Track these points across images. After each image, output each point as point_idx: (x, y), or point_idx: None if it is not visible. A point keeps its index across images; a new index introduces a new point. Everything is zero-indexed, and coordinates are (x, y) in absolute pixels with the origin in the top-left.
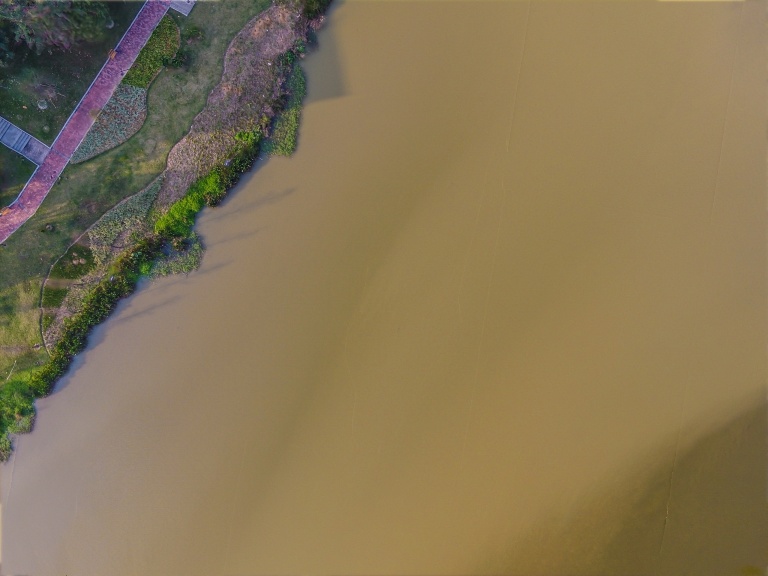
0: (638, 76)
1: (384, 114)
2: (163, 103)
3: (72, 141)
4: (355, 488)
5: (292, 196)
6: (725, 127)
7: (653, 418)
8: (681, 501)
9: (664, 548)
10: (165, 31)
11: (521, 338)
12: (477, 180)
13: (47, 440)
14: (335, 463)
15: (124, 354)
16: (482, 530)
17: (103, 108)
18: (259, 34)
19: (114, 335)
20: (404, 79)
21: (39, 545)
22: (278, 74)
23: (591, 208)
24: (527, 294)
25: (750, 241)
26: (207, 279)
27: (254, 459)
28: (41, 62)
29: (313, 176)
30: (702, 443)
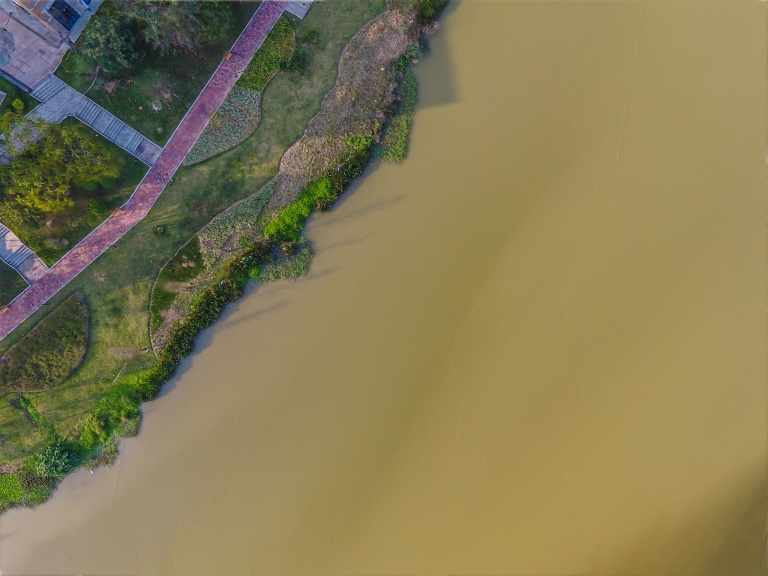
0: (748, 89)
1: (495, 122)
2: (277, 106)
3: (185, 143)
4: (461, 497)
5: (402, 202)
6: None
7: (757, 431)
8: None
9: (765, 561)
10: (280, 34)
11: (628, 349)
12: (587, 190)
13: (152, 444)
14: (441, 471)
15: (231, 358)
16: (586, 540)
17: (216, 110)
18: (373, 39)
19: (221, 339)
20: (515, 87)
21: (143, 549)
22: (390, 79)
23: (700, 220)
24: (635, 305)
25: None
26: (315, 284)
27: (360, 466)
28: (158, 63)
29: (423, 183)
30: None
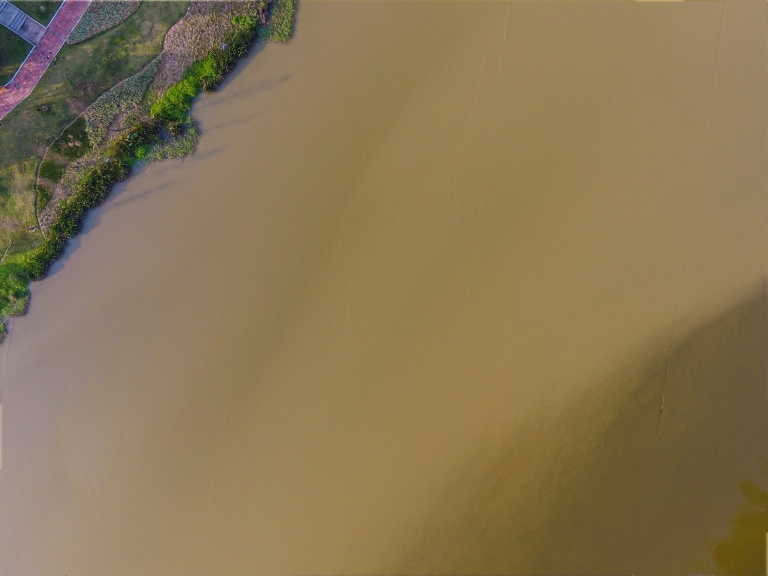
0: None
1: (381, 1)
2: None
3: (68, 22)
4: (350, 374)
5: (289, 82)
6: (724, 18)
7: (649, 308)
8: (677, 392)
9: (660, 439)
10: None
11: (517, 227)
12: (474, 67)
13: (41, 323)
14: (330, 349)
15: (119, 238)
16: (477, 418)
17: None
18: None
19: (109, 219)
20: None
21: (32, 428)
22: None
23: (589, 97)
24: (524, 182)
25: (748, 132)
26: (203, 164)
27: (249, 344)
28: None
29: (310, 62)
30: (698, 334)
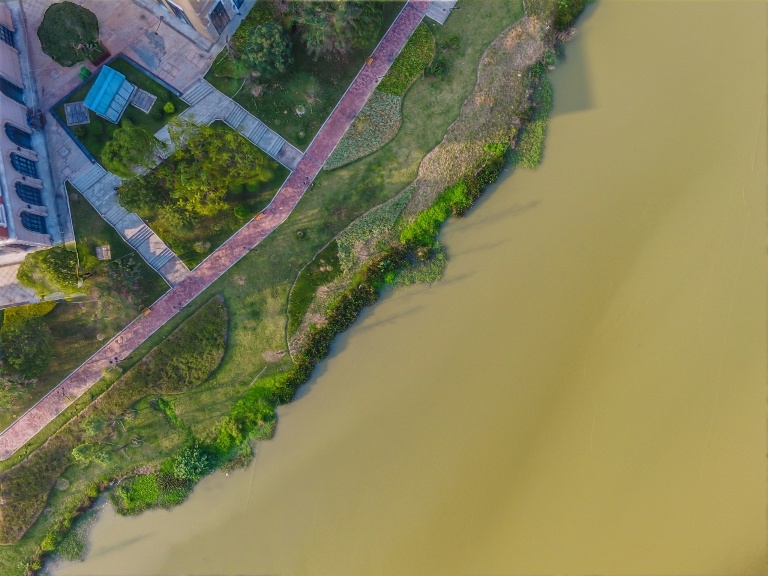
0: None
1: (630, 129)
2: (418, 112)
3: (325, 147)
4: (593, 503)
5: (536, 208)
6: None
7: None
8: None
9: None
10: (421, 39)
11: (760, 358)
12: (722, 198)
13: (287, 447)
14: (574, 478)
15: (366, 363)
16: (719, 549)
17: (357, 115)
18: (511, 45)
19: (356, 343)
20: (649, 94)
21: (277, 552)
22: (527, 85)
23: None
24: None
25: None
26: (450, 290)
27: (493, 472)
28: (303, 67)
29: (558, 189)
30: None
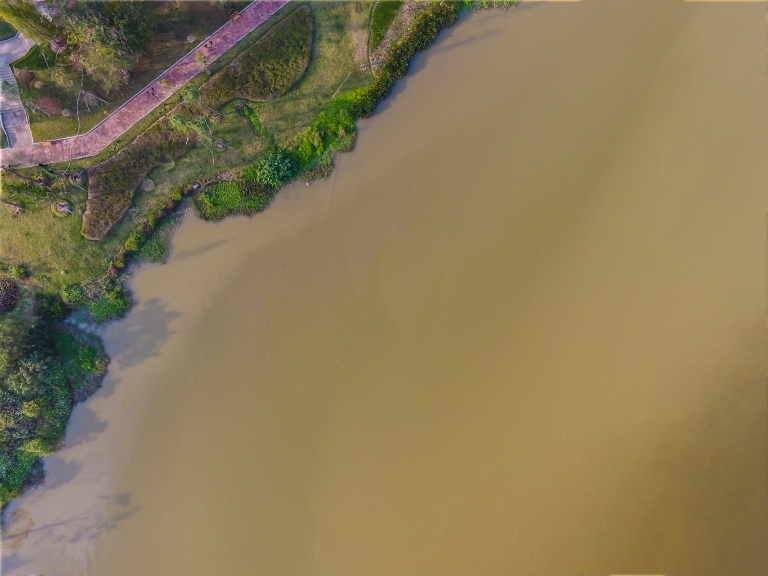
0: None
1: None
2: None
3: None
4: (665, 223)
5: None
6: None
7: None
8: None
9: None
10: None
11: None
12: None
13: (366, 160)
14: (646, 198)
15: (444, 81)
16: None
17: None
18: None
19: (435, 63)
20: None
21: (354, 262)
22: None
23: None
24: None
25: None
26: (527, 14)
27: (567, 190)
28: None
29: None
30: None
